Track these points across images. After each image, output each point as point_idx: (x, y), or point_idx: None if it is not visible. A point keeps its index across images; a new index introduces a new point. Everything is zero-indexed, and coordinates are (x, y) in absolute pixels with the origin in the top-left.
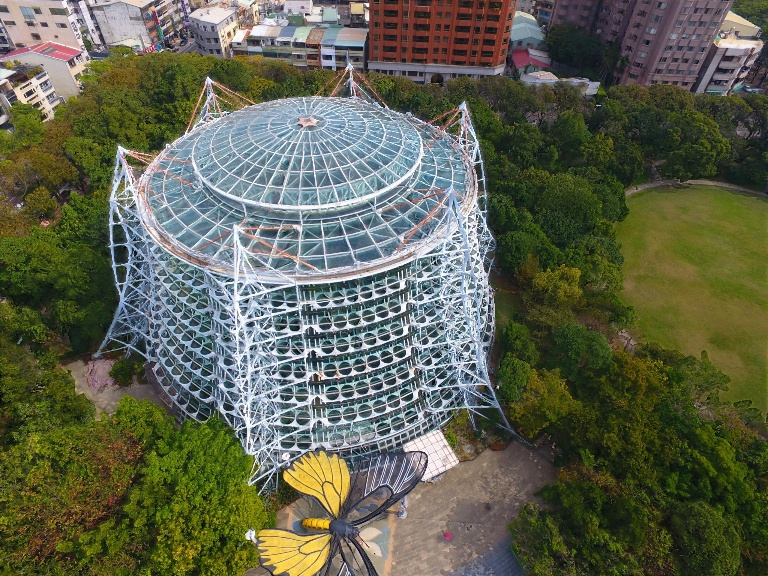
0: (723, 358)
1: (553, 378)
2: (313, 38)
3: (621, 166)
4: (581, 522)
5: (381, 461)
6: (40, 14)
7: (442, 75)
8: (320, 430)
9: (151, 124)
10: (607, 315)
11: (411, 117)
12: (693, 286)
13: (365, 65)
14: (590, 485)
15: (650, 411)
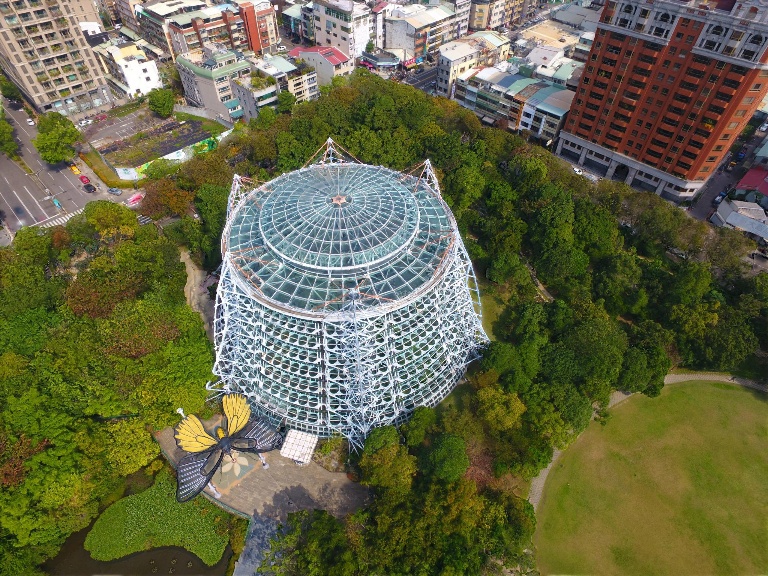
0: (607, 569)
1: (406, 460)
2: (523, 94)
3: (704, 347)
4: (308, 539)
5: (264, 426)
6: (335, 28)
7: (629, 168)
8: (259, 387)
9: (340, 135)
10: (513, 455)
11: (452, 217)
12: (662, 499)
13: (558, 132)
14: (337, 528)
15: (448, 534)
